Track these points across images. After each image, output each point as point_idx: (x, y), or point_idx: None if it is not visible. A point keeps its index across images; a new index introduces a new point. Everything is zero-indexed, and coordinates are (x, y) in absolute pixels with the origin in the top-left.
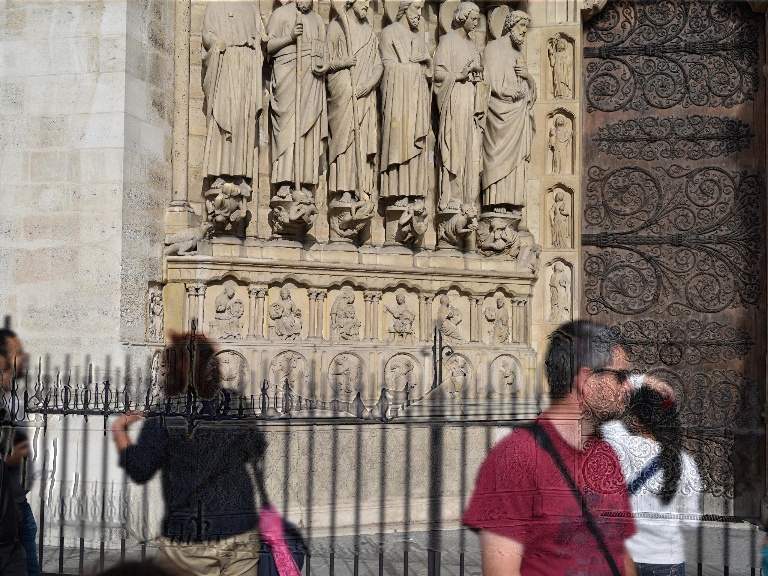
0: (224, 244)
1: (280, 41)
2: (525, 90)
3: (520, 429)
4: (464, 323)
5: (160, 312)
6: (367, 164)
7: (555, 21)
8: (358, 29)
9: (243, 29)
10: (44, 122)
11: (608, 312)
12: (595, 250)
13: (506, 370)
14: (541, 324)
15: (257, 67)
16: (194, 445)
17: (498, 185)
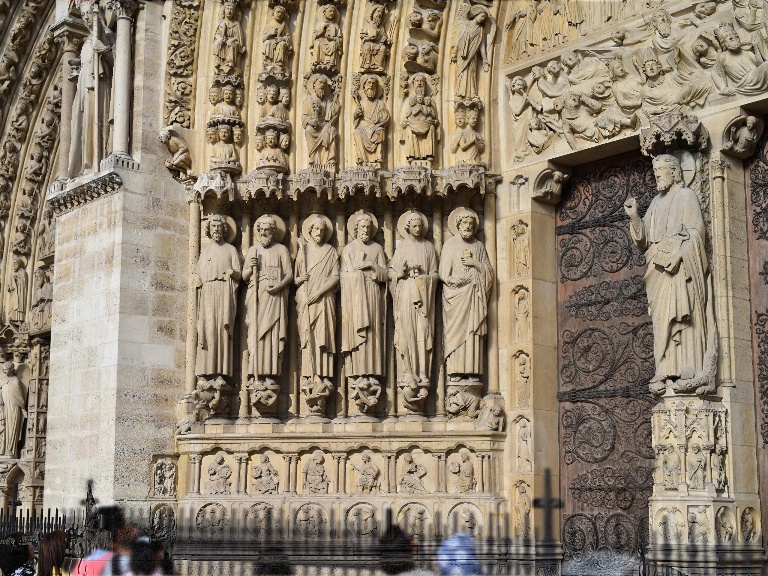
0: (212, 424)
1: (247, 272)
2: (471, 276)
3: (481, 568)
4: (429, 476)
5: (171, 476)
6: (324, 354)
7: (519, 210)
8: (316, 251)
9: (216, 268)
10: (89, 351)
11: (579, 461)
12: (569, 405)
13: (466, 516)
14: (510, 475)
15: (226, 294)
16: (185, 574)
17: (450, 358)
